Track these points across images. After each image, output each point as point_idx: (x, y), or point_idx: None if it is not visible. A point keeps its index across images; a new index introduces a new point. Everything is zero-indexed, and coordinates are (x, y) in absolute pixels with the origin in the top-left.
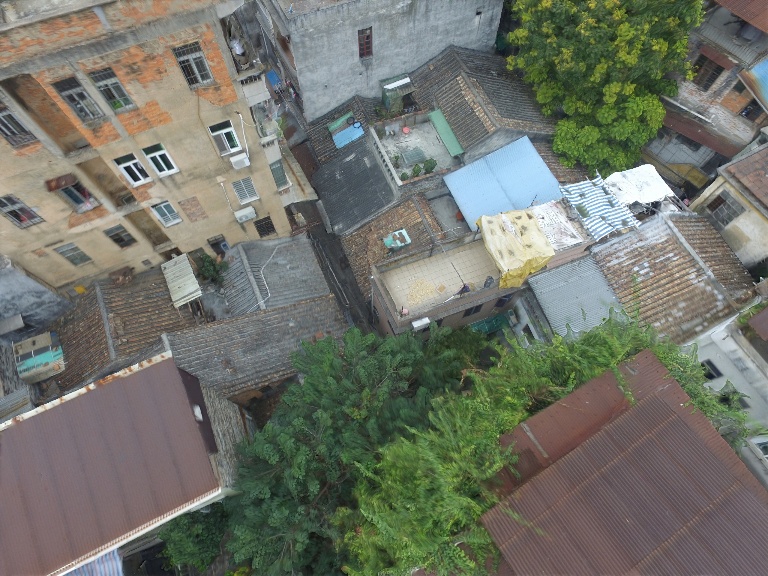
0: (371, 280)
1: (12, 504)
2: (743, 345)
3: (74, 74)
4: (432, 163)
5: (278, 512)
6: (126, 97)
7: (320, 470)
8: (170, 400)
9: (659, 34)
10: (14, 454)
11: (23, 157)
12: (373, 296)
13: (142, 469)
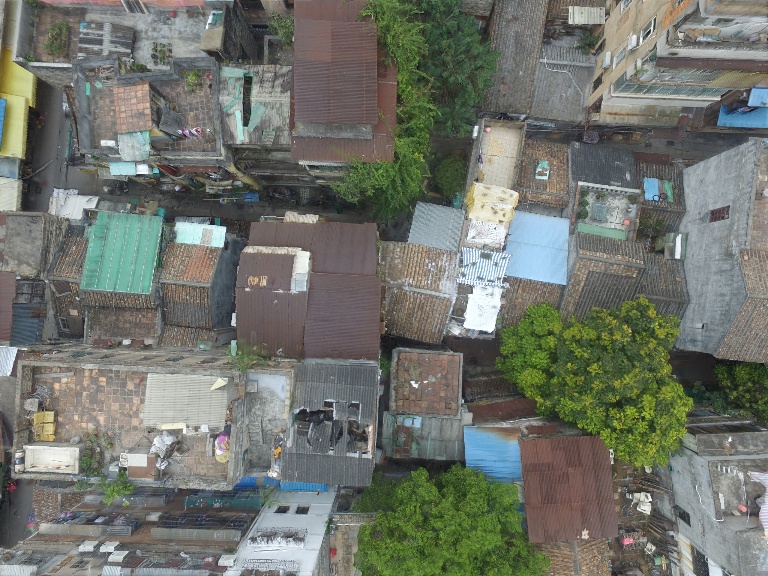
0: None
1: None
2: None
3: None
4: (584, 214)
5: None
6: None
7: None
8: None
9: None
10: None
11: None
12: None
13: None
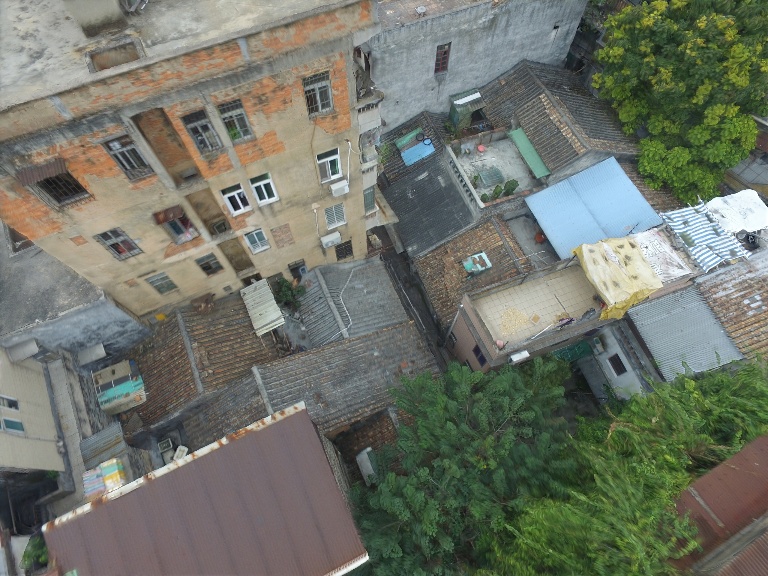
0: (461, 309)
1: (149, 571)
2: None
3: (204, 107)
4: (514, 184)
5: (417, 575)
6: (247, 128)
7: None
8: (307, 456)
9: (766, 54)
10: (148, 515)
11: (137, 191)
12: (455, 323)
13: (283, 532)
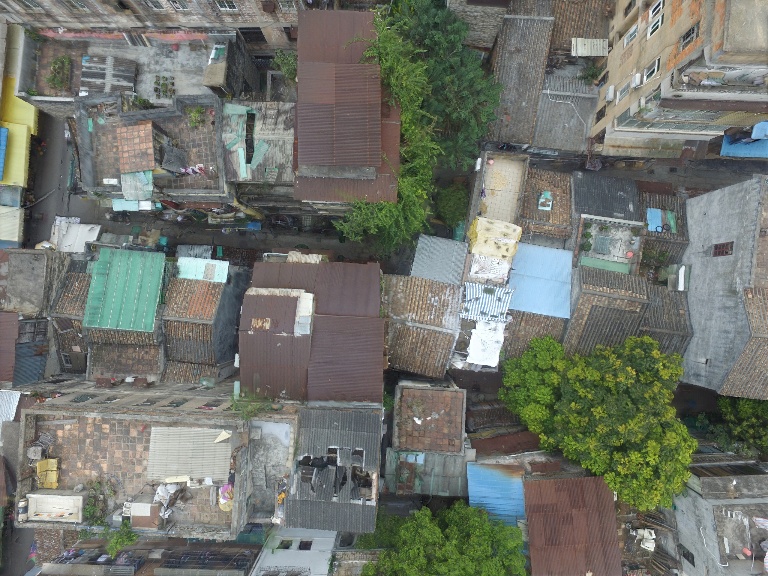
0: None
1: None
2: None
3: None
4: (587, 246)
5: (426, 19)
6: None
7: None
8: None
9: None
10: None
11: None
12: None
13: None
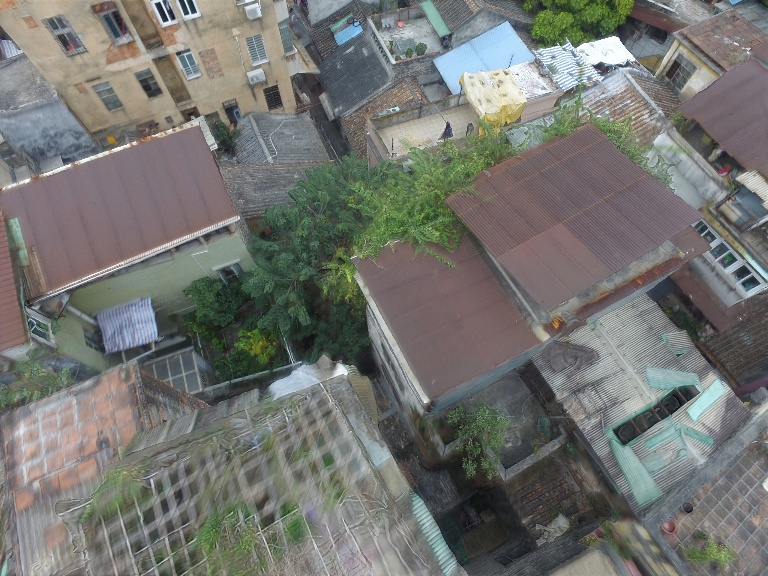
0: (367, 136)
1: (73, 222)
2: (677, 138)
3: None
4: (423, 46)
5: (285, 254)
6: None
7: (320, 247)
8: (198, 156)
9: None
10: (73, 188)
11: None
12: (369, 161)
13: (176, 202)
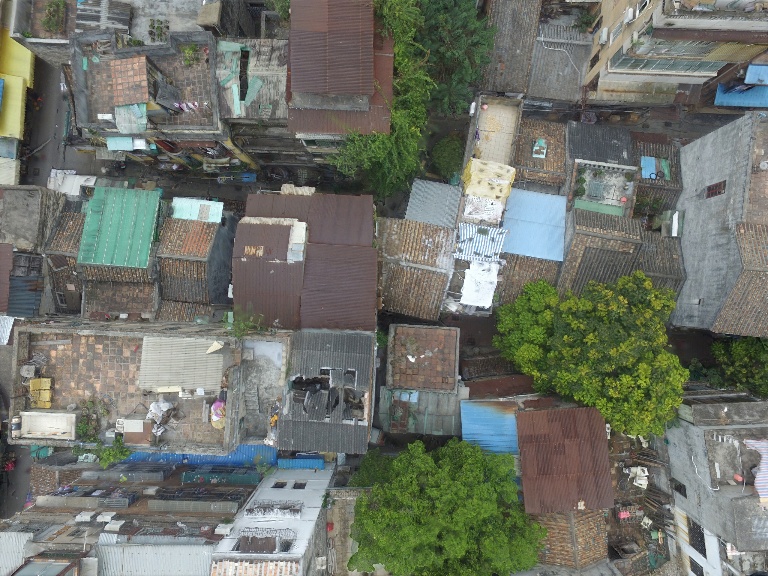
0: None
1: None
2: None
3: None
4: (581, 191)
5: None
6: None
7: None
8: None
9: None
10: None
11: None
12: None
13: None
